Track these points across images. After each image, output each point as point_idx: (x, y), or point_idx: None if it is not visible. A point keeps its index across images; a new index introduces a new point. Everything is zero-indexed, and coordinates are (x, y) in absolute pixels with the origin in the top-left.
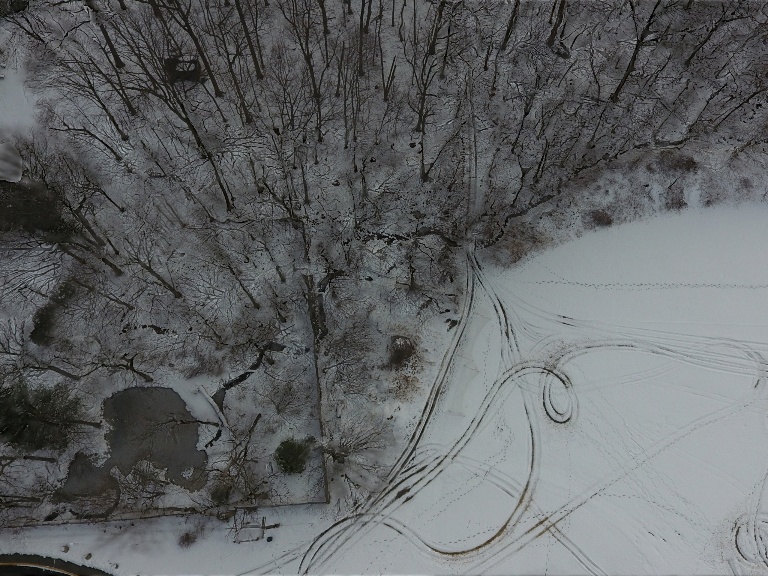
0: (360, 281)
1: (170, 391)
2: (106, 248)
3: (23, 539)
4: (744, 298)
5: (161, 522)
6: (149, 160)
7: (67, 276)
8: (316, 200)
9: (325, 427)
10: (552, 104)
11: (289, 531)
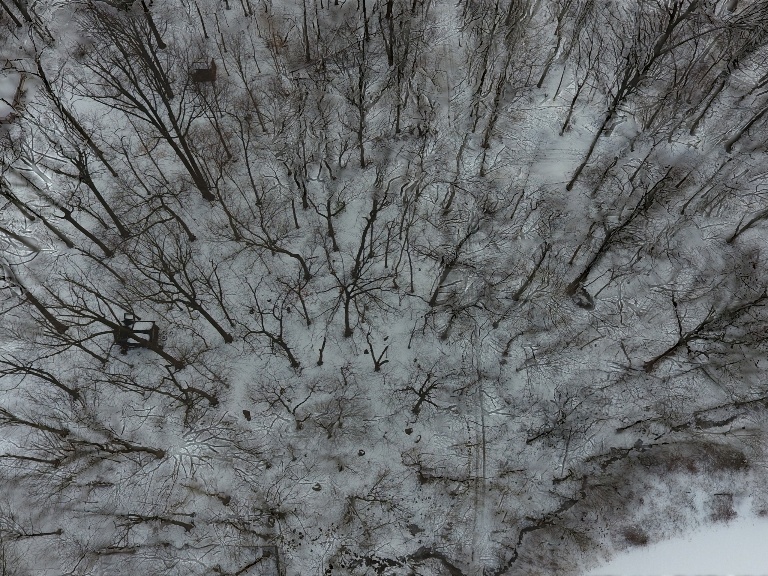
0: None
1: None
2: None
3: None
4: None
5: None
6: (92, 467)
7: None
8: (293, 513)
9: None
10: (574, 383)
11: None
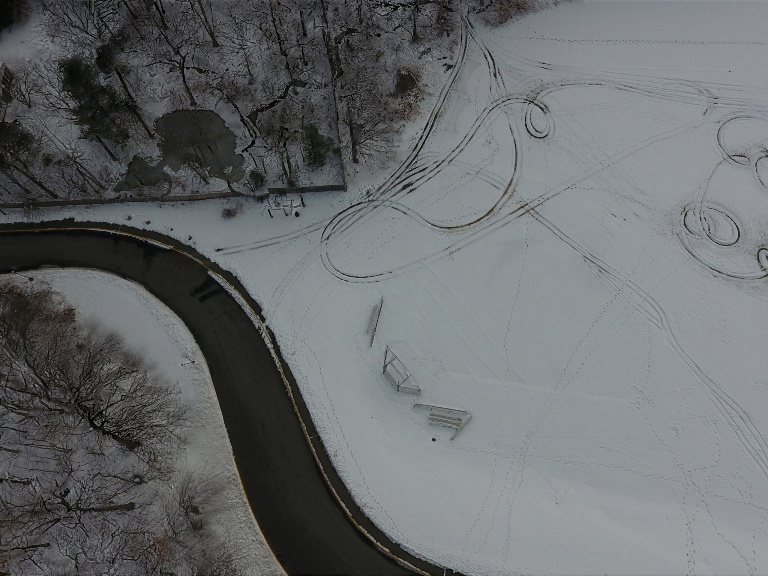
0: (370, 36)
1: (211, 113)
2: (156, 1)
3: (93, 212)
4: (697, 51)
5: (207, 203)
6: None
7: (123, 23)
8: None
9: (342, 137)
10: None
11: (313, 210)
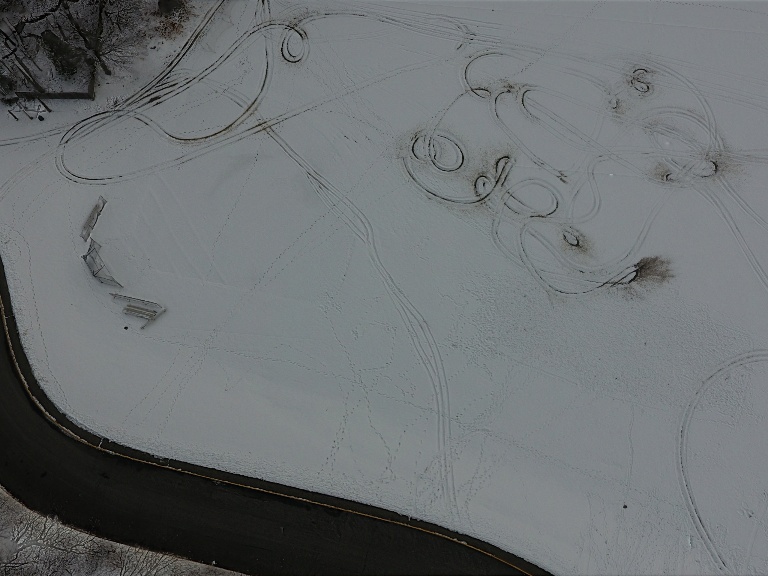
0: None
1: None
2: None
3: None
4: None
5: None
6: None
7: None
8: None
9: None
10: None
11: (58, 115)
